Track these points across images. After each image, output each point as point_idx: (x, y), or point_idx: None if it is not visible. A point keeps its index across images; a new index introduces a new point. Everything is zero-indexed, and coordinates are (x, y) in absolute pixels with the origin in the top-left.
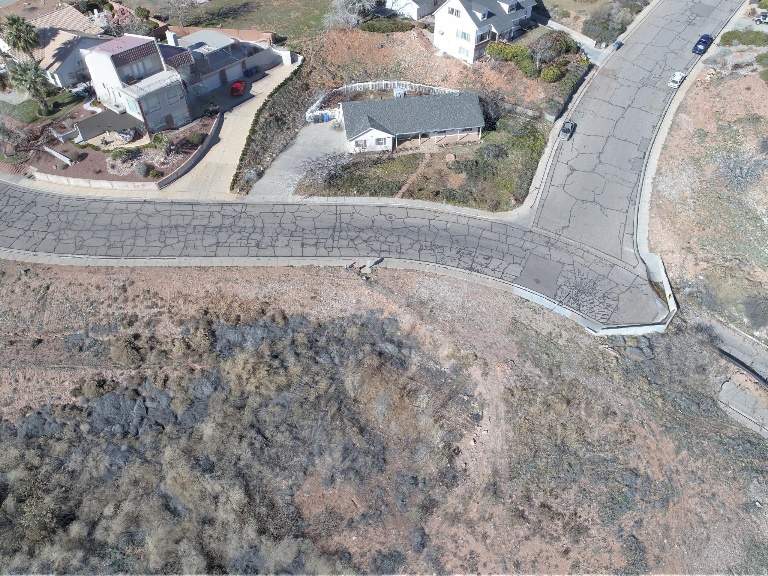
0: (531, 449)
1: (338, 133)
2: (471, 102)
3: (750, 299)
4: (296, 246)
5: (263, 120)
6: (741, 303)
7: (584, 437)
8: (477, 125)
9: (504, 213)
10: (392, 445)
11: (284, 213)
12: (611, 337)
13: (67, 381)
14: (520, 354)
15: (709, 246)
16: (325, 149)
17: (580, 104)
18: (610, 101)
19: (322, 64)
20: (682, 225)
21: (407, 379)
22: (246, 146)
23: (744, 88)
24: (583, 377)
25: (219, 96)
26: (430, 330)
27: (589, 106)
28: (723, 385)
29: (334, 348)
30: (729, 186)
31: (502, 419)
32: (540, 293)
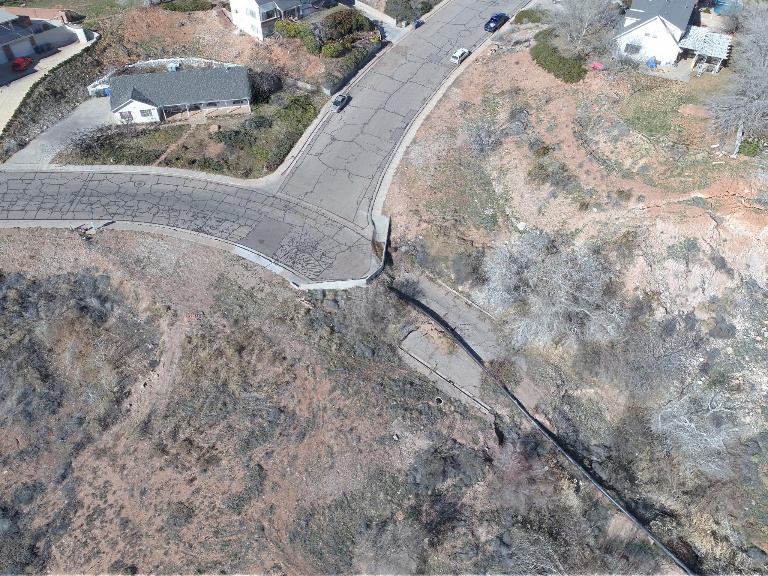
0: (193, 390)
1: (109, 106)
2: (239, 75)
3: (456, 256)
4: (31, 210)
5: (37, 93)
6: (451, 260)
7: (247, 379)
8: (242, 97)
9: (254, 180)
10: (72, 390)
11: (33, 180)
12: (312, 291)
13: None
14: (213, 306)
15: (434, 208)
16: (96, 121)
17: (362, 79)
18: (392, 76)
19: (118, 41)
20: (417, 189)
21: (102, 330)
22: (13, 118)
23: (514, 62)
24: (267, 326)
25: (1, 71)
26: (135, 285)
27: (370, 81)
28: (409, 334)
29: (42, 303)
30: (473, 153)
31: (175, 364)
32: (260, 252)
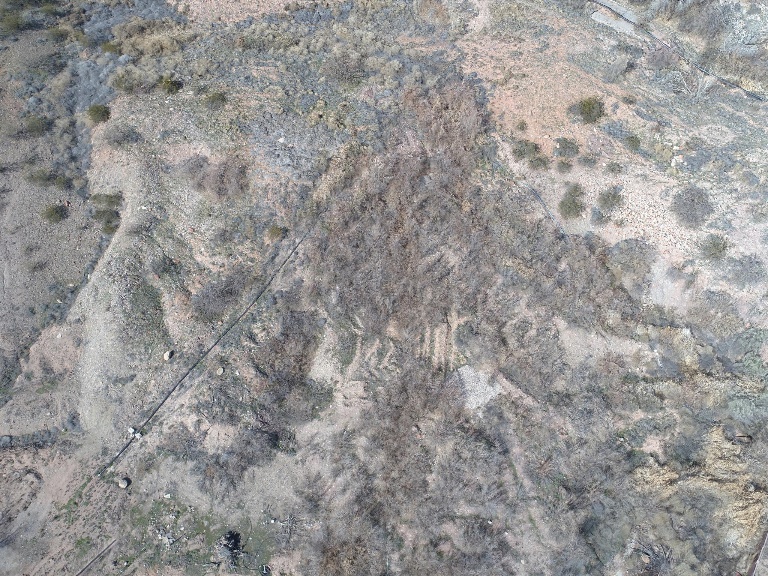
0: None
1: None
2: None
3: None
4: None
5: None
6: None
7: None
8: None
9: None
10: (437, 26)
11: None
12: None
13: (282, 4)
14: None
15: None
16: None
17: None
18: None
19: None
20: None
21: (442, 6)
22: None
23: None
24: (526, 3)
25: None
26: None
27: None
28: (594, 12)
29: None
30: None
31: (488, 13)
32: None
